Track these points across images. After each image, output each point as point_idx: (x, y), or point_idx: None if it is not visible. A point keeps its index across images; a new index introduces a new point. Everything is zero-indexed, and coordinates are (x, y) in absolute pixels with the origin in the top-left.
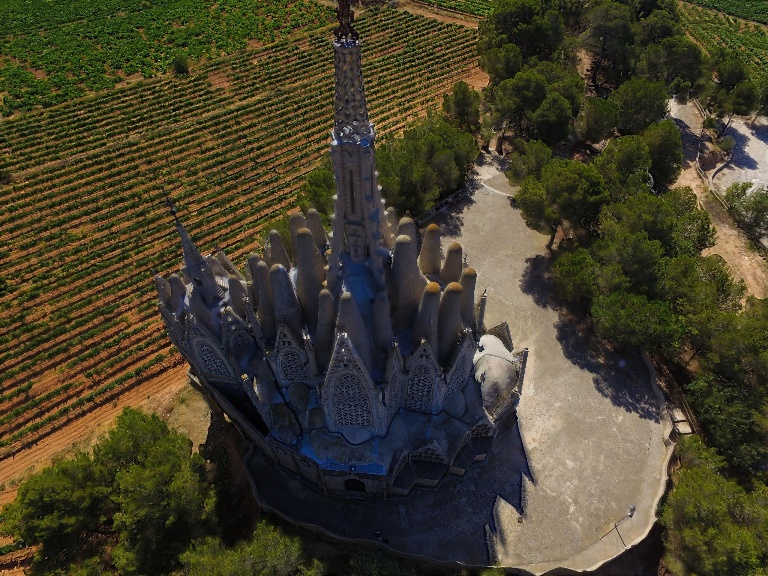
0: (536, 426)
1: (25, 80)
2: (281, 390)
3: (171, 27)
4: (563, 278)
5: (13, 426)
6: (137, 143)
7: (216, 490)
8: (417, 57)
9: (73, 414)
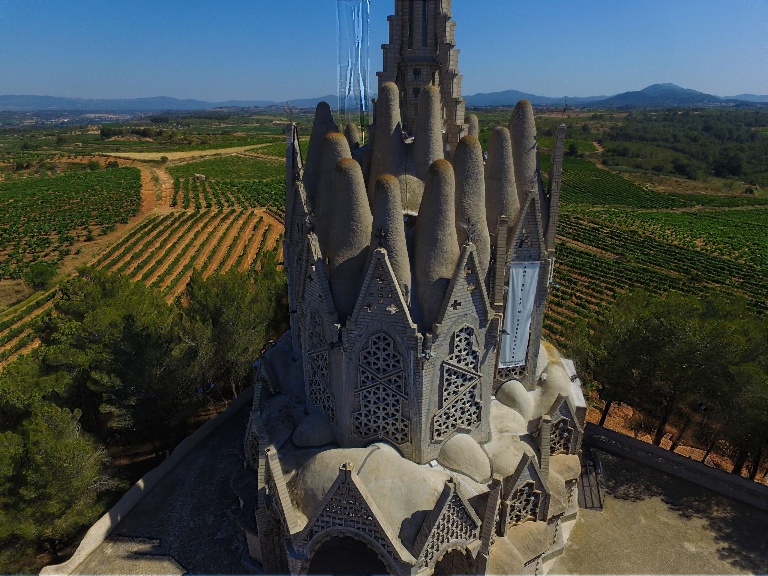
0: None
1: None
2: None
3: None
4: None
5: None
6: None
7: None
8: None
9: None
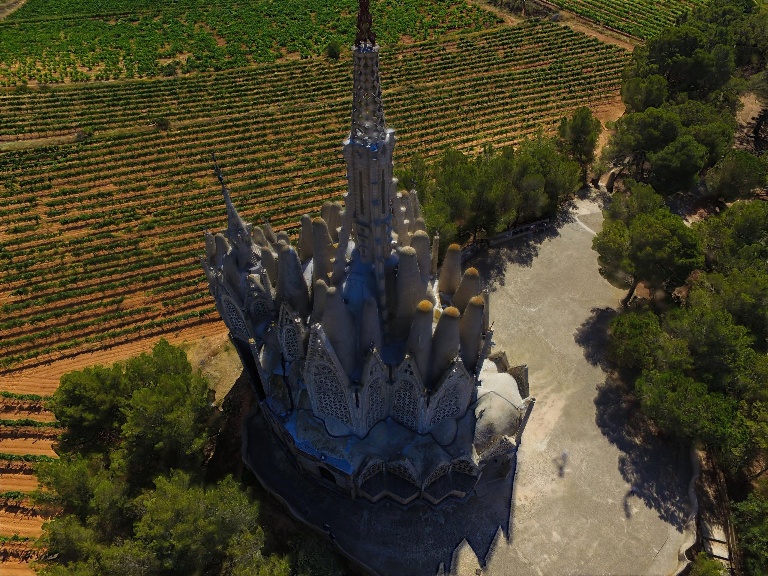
0: (534, 484)
1: (208, 45)
2: (285, 363)
3: (339, 14)
4: (617, 339)
5: (100, 328)
6: (273, 114)
7: (209, 434)
8: (561, 75)
9: (144, 333)
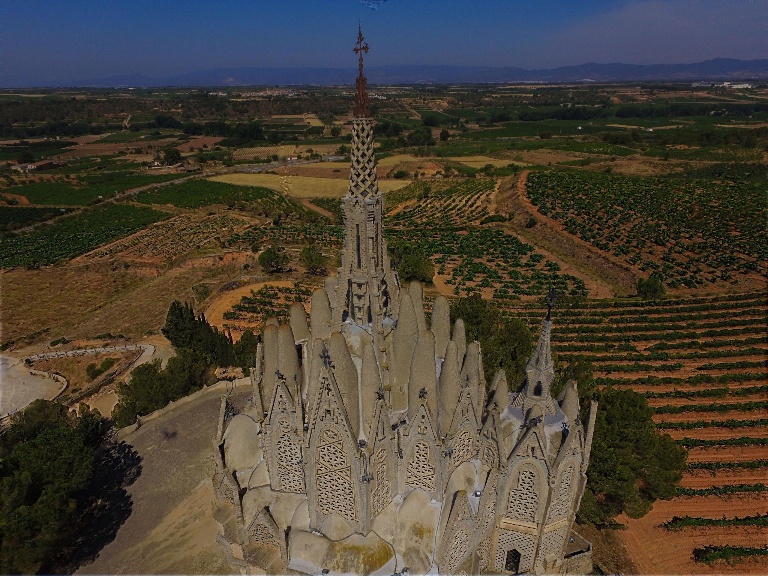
0: None
1: None
2: None
3: None
4: None
5: None
6: None
7: None
8: None
9: None
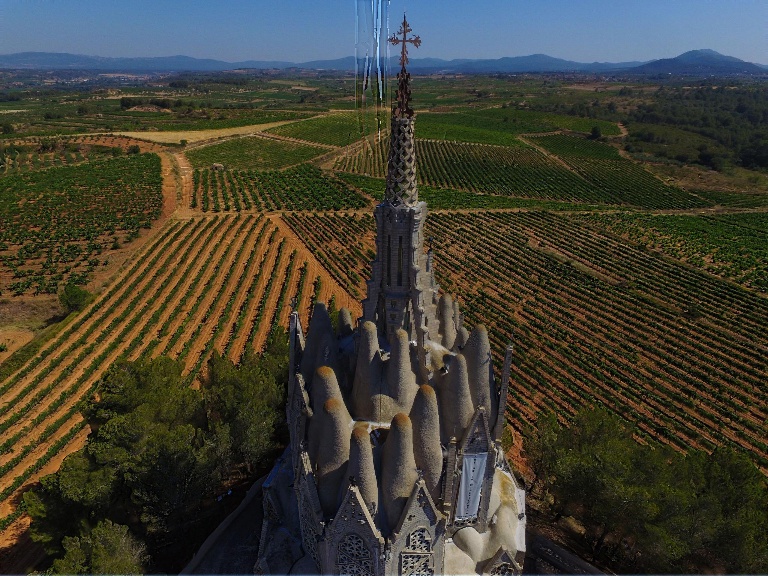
0: None
1: None
2: None
3: None
4: None
5: None
6: None
7: None
8: None
9: None
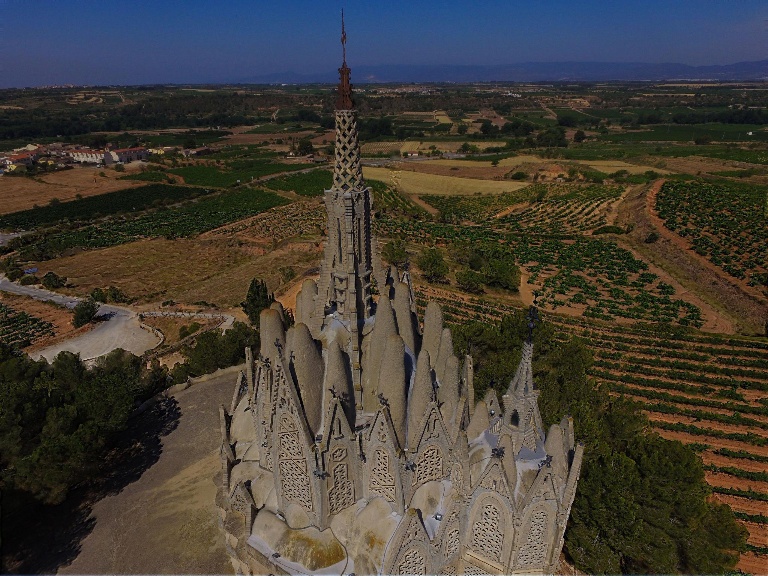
0: None
1: None
2: None
3: None
4: None
5: None
6: None
7: None
8: None
9: None
